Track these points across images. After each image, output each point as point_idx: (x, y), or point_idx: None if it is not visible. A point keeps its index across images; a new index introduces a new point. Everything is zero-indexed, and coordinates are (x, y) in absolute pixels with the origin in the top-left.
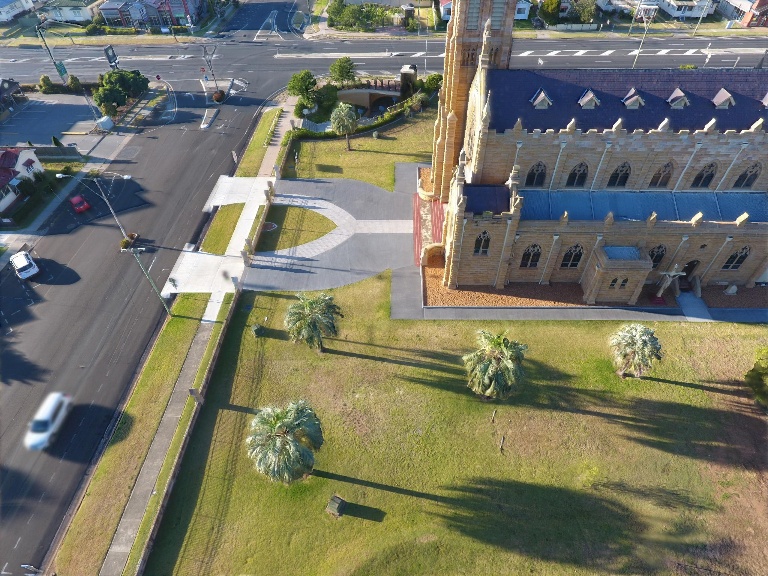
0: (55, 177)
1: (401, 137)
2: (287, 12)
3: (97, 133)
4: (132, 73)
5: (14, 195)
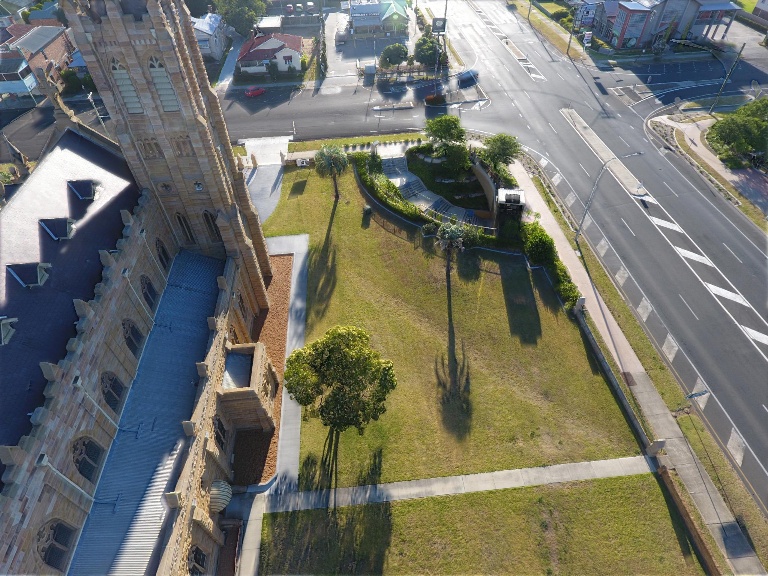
0: (287, 74)
1: (370, 232)
2: (735, 88)
3: (359, 71)
4: (435, 47)
5: (265, 69)
